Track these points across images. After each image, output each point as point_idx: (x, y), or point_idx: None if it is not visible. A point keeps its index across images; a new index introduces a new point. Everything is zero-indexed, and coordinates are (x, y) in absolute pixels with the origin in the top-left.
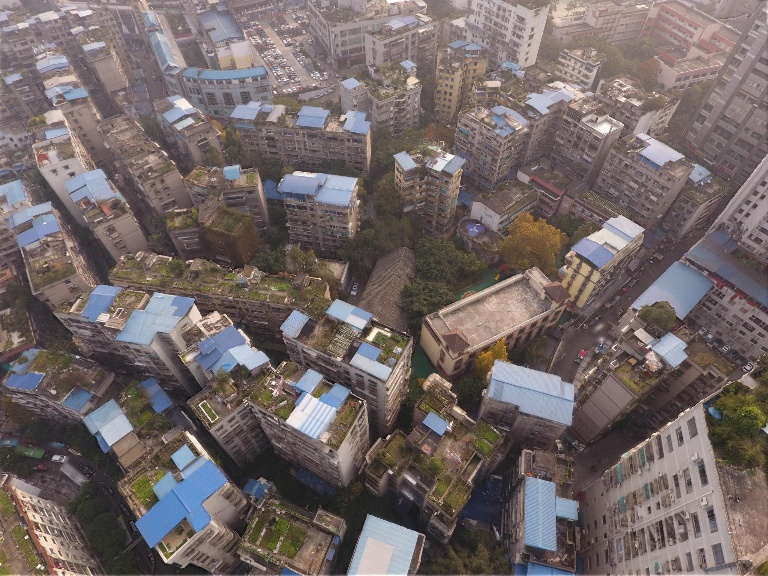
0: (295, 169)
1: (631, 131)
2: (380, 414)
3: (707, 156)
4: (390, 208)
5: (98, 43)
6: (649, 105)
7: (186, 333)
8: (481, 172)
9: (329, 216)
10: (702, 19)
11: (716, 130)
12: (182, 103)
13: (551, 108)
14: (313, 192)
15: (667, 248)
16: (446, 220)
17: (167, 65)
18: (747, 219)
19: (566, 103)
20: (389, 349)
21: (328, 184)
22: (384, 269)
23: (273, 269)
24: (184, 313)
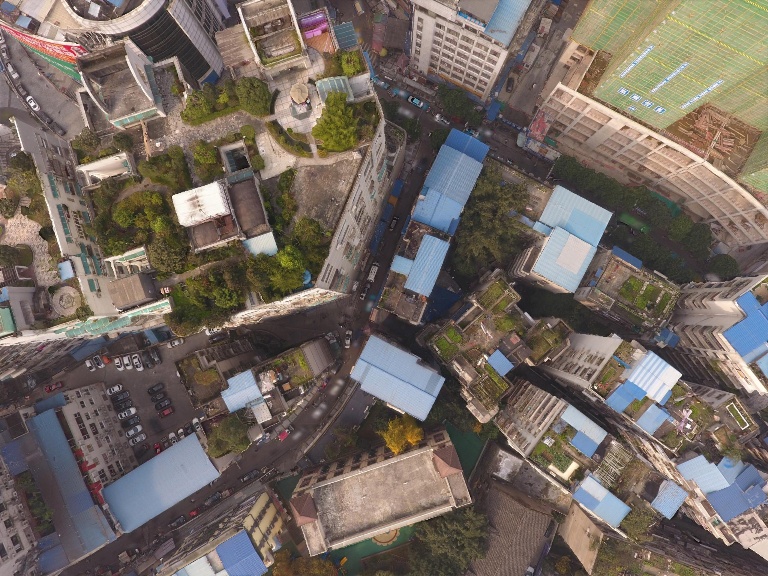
0: None
1: None
2: None
3: None
4: None
5: None
6: None
7: None
8: None
9: None
10: None
11: None
12: None
13: None
14: None
15: (104, 570)
16: None
17: None
18: None
19: None
20: (556, 446)
21: None
22: None
23: None
24: None
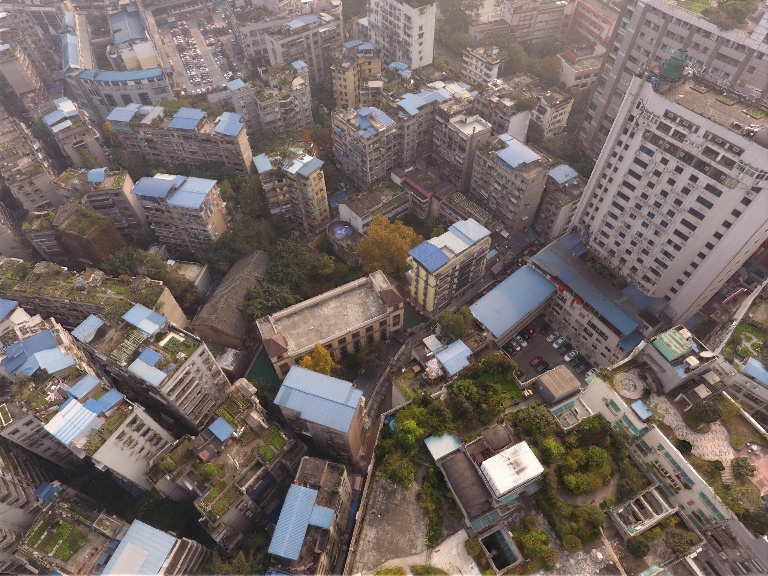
0: (174, 171)
1: (505, 131)
2: (186, 418)
3: (596, 156)
4: (249, 210)
5: (3, 45)
6: (521, 105)
7: (2, 336)
8: (357, 173)
9: (186, 218)
10: (616, 15)
11: (601, 130)
12: (66, 105)
13: (425, 108)
14: (164, 195)
15: (539, 250)
16: (316, 222)
17: (68, 67)
18: (593, 222)
19: (439, 103)
20: (176, 354)
21: (185, 186)
22: (236, 272)
23: (118, 272)
24: (3, 316)
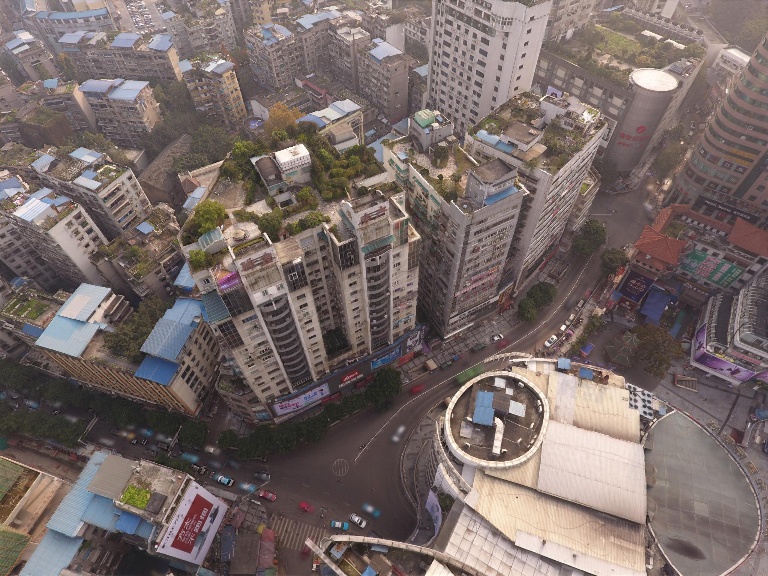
0: None
1: None
2: None
3: None
4: (176, 105)
5: None
6: (395, 19)
7: None
8: (268, 81)
9: (125, 112)
10: None
11: None
12: (24, 35)
13: (320, 25)
14: (105, 90)
15: None
16: (235, 119)
17: (25, 10)
18: None
19: None
20: None
21: (123, 86)
22: (166, 150)
23: None
24: None
